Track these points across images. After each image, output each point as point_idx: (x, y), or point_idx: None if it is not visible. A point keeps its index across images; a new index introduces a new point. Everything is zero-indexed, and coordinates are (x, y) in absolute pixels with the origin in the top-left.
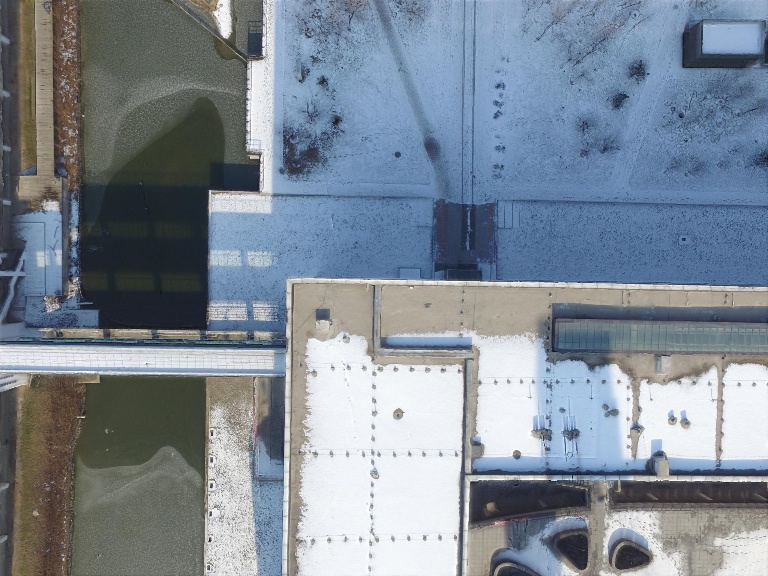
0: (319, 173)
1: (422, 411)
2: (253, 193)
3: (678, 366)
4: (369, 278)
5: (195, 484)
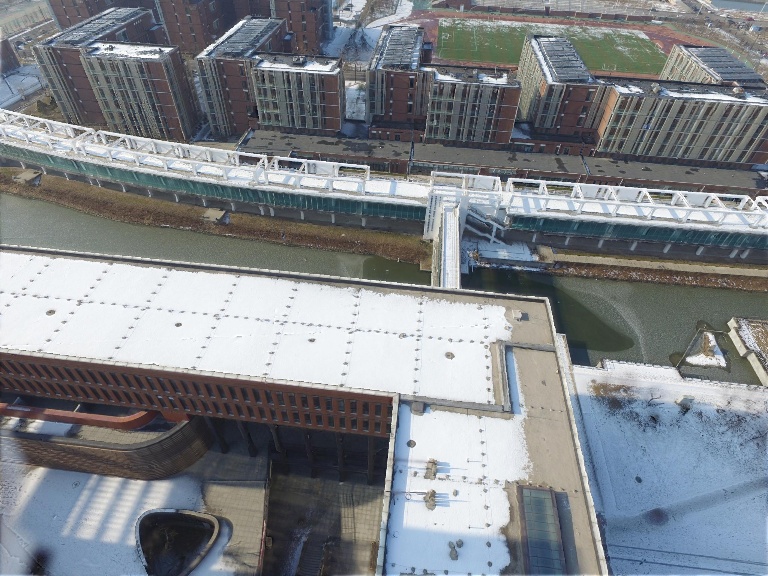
0: (600, 408)
1: (453, 372)
2: (570, 361)
3: None
4: None
5: None
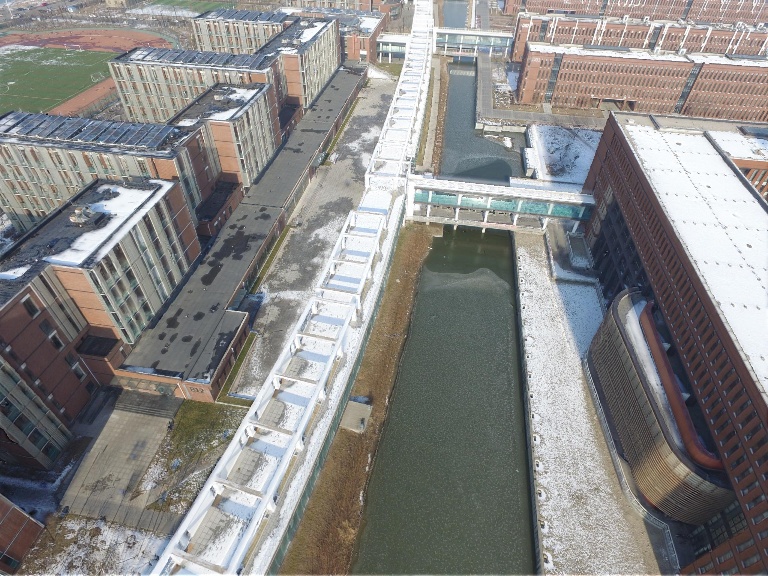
0: (567, 176)
1: (690, 144)
2: (533, 179)
3: None
4: None
5: (505, 287)
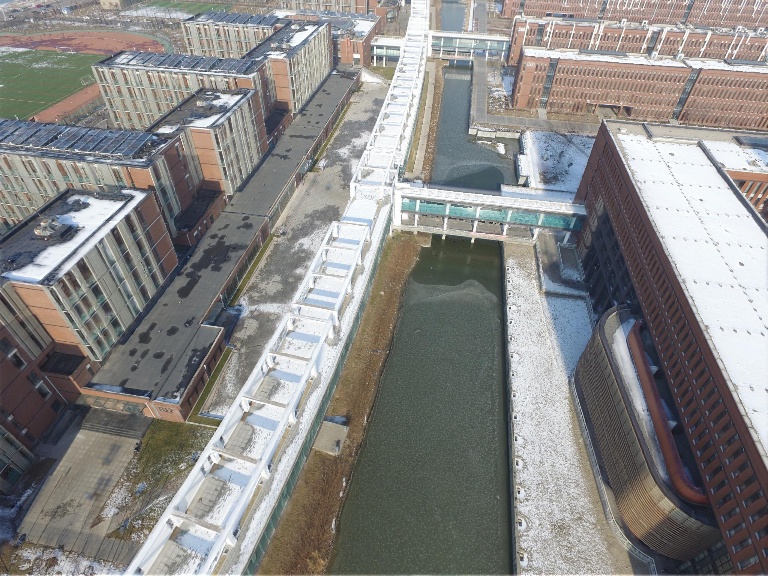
0: (560, 184)
1: (684, 154)
2: (525, 187)
3: None
4: None
5: (492, 300)
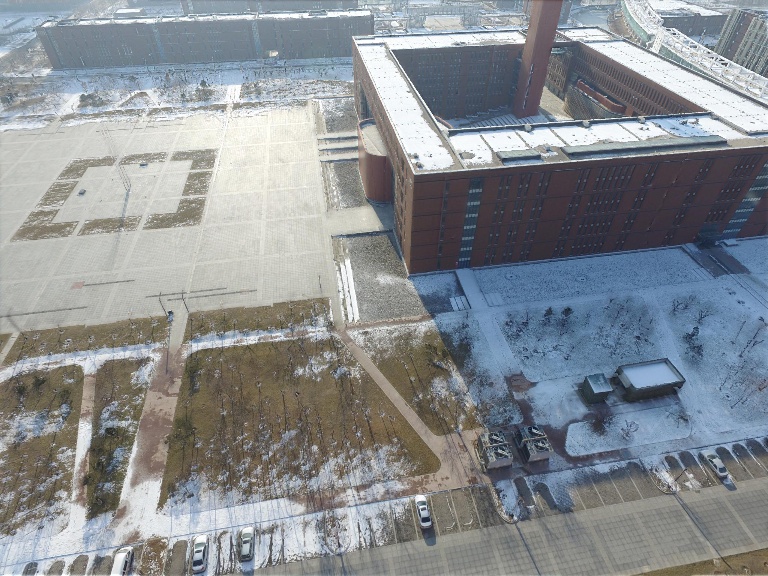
0: None
1: None
2: None
3: None
4: (751, 238)
5: None
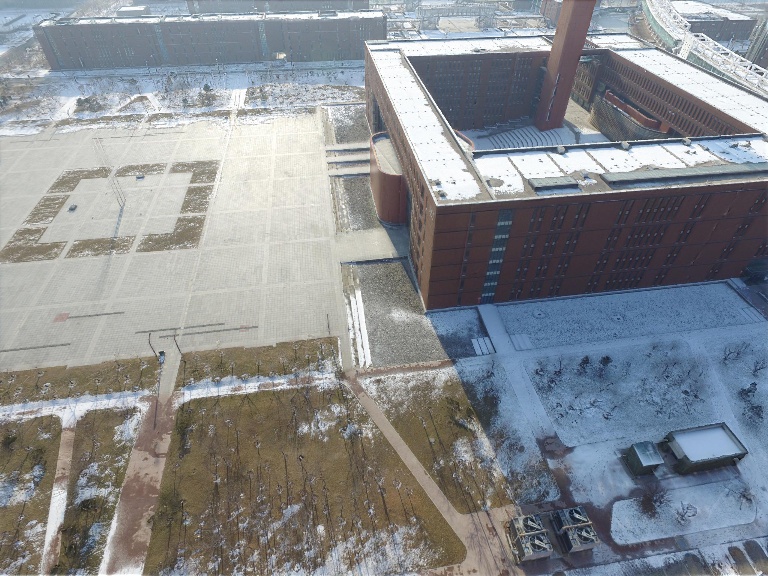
0: None
1: None
2: None
3: (710, 165)
4: None
5: None
